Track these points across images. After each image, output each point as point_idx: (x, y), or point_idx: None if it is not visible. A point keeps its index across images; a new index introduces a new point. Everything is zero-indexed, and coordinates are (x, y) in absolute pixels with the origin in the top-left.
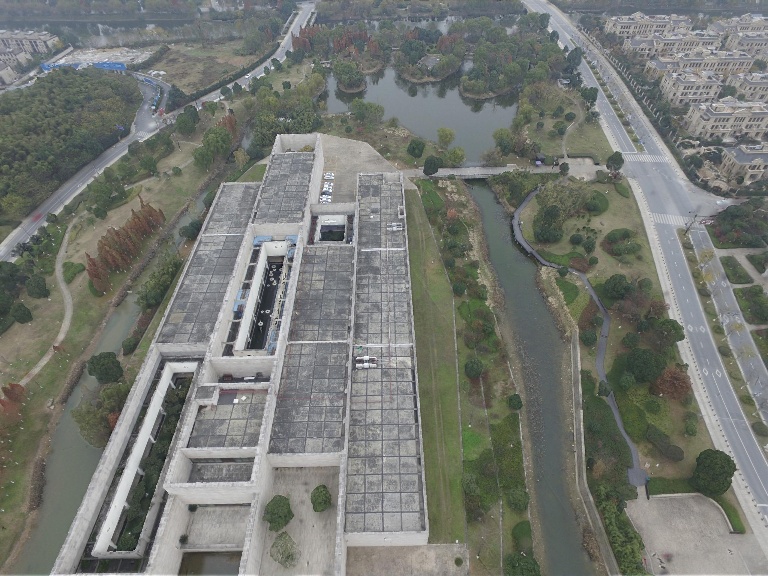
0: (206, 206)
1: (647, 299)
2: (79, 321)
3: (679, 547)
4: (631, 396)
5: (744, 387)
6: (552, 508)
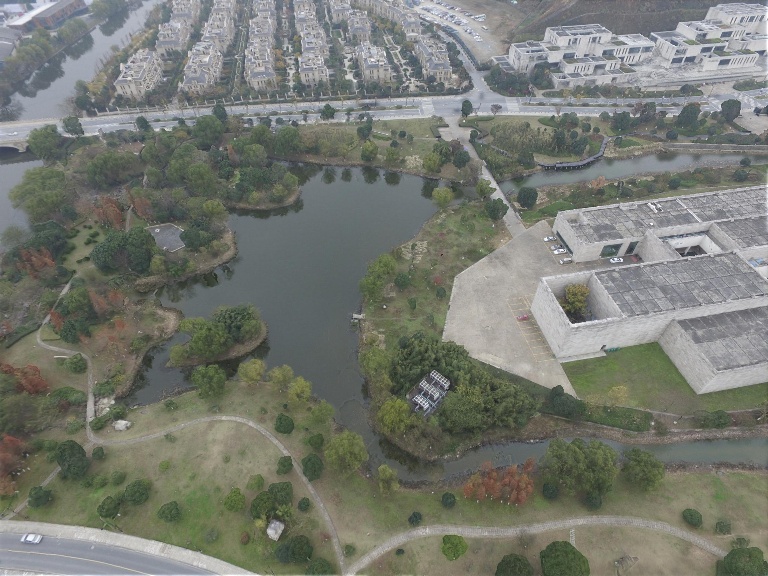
0: None
1: None
2: None
3: (765, 128)
4: (697, 130)
5: None
6: None
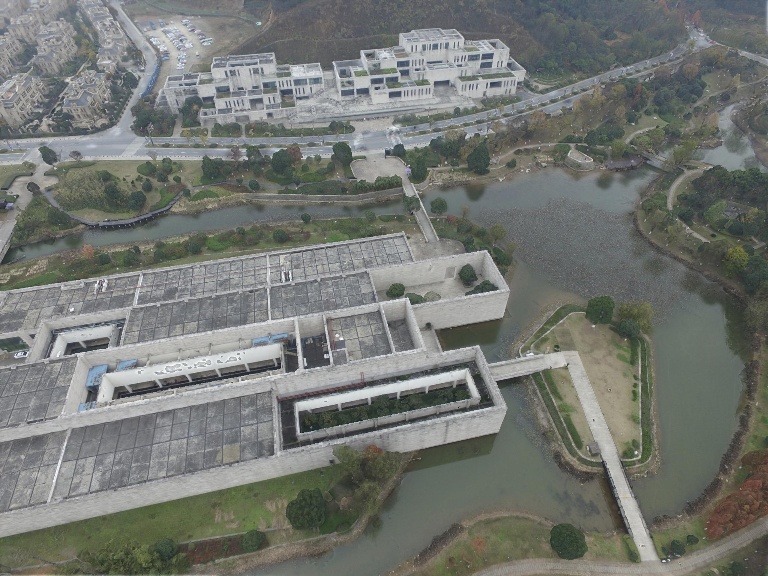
0: None
1: (222, 160)
2: None
3: (377, 173)
4: None
5: None
6: None
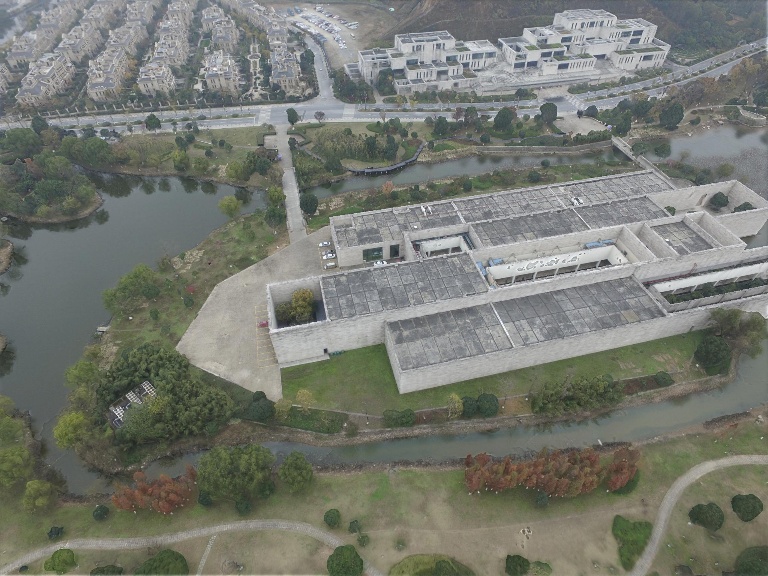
0: (414, 421)
1: None
2: (679, 463)
3: None
4: (514, 133)
5: (485, 108)
6: (588, 160)
